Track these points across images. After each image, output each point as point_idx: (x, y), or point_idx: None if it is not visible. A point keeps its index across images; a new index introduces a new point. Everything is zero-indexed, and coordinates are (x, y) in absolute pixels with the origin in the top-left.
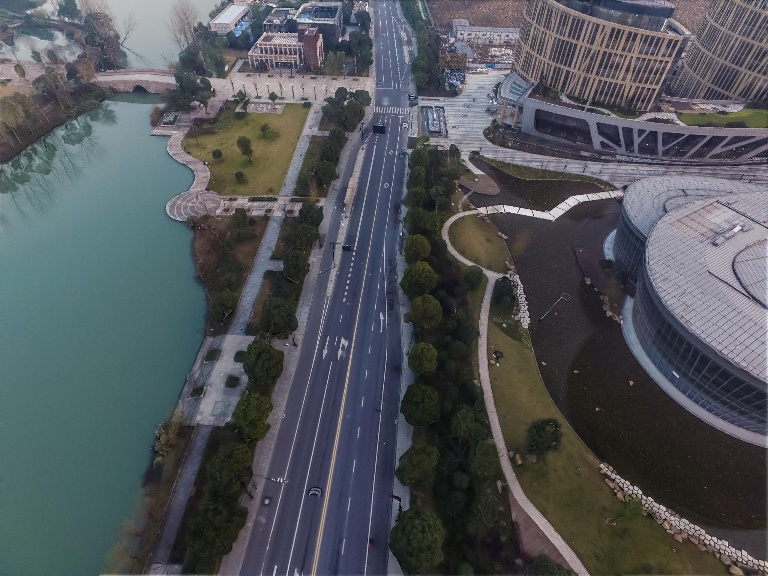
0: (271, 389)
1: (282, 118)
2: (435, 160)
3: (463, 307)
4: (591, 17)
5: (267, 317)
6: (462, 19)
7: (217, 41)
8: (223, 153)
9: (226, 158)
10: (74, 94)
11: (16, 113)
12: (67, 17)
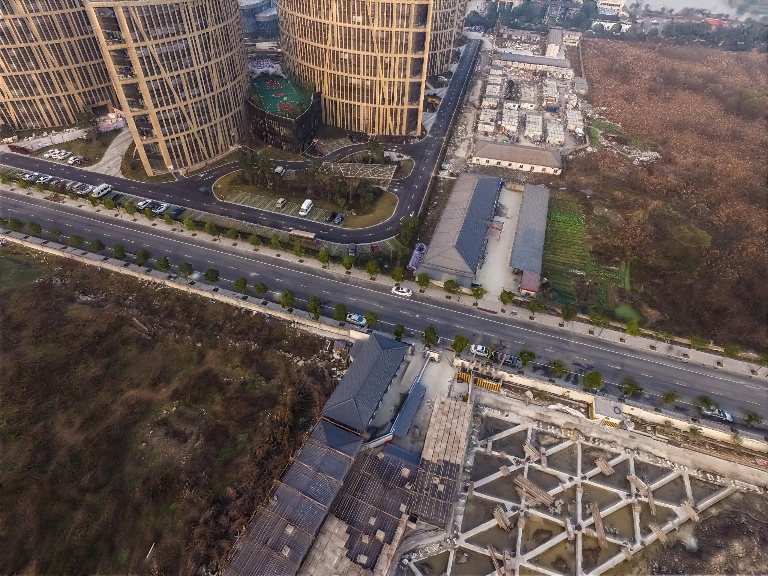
0: None
1: None
2: None
3: None
4: None
5: None
6: (581, 33)
7: None
8: None
9: None
10: None
11: None
12: None
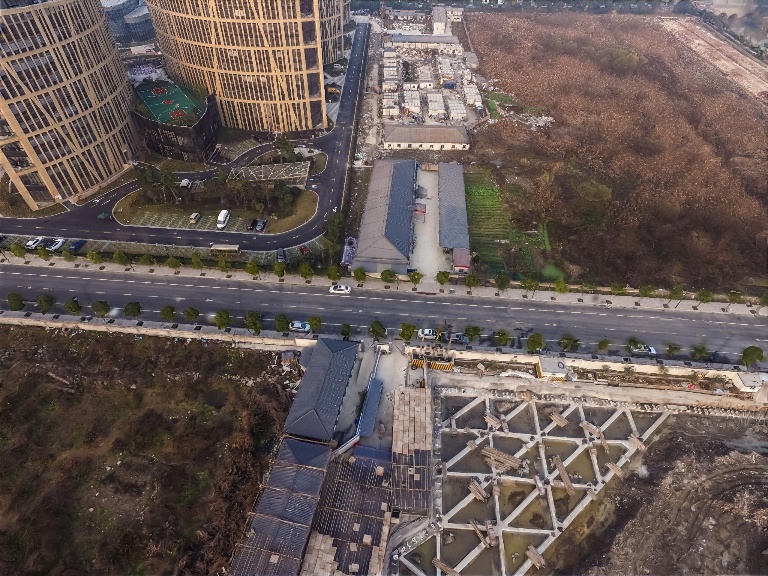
0: None
1: None
2: None
3: None
4: None
5: None
6: (462, 9)
7: None
8: None
9: None
10: None
11: None
12: None
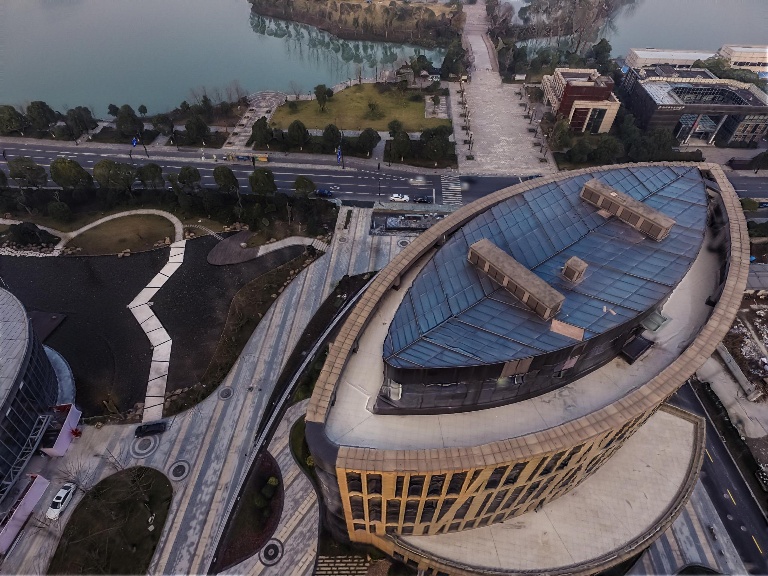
0: (48, 138)
1: (414, 119)
2: (279, 203)
3: (43, 213)
4: (436, 225)
5: (110, 132)
6: None
7: (569, 57)
8: (344, 100)
9: (335, 102)
10: (438, 33)
11: (376, 17)
12: (605, 3)
